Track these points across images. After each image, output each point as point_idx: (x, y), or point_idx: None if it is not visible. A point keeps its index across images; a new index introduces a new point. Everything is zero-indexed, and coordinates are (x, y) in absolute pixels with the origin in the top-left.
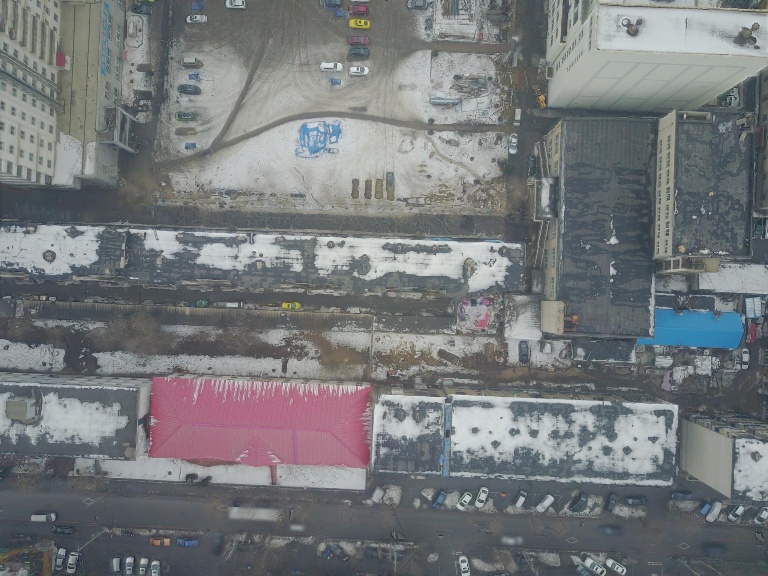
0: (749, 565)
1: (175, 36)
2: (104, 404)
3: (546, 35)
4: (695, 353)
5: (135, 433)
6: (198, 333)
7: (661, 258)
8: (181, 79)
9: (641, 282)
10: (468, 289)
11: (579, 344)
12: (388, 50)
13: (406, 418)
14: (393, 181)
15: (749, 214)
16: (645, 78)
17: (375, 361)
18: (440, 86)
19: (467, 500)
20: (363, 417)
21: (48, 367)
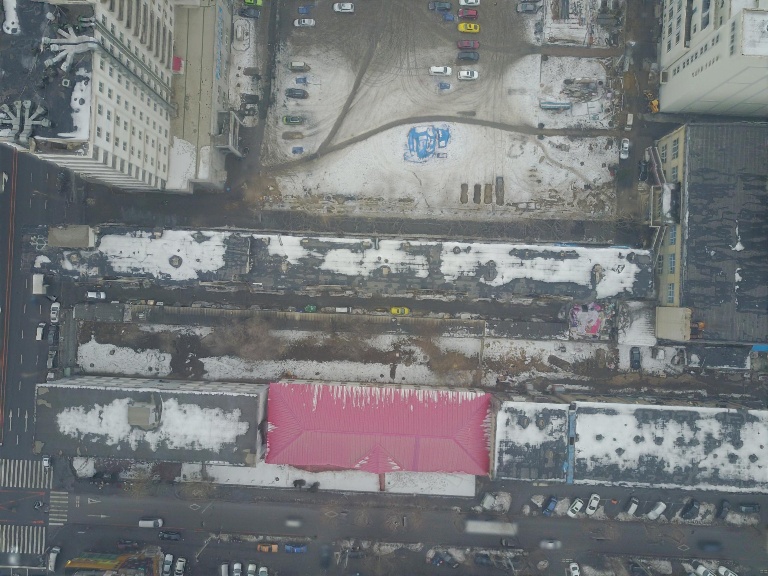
0: None
1: (282, 40)
2: (224, 410)
3: (657, 39)
4: None
5: (255, 439)
6: (306, 338)
7: None
8: (288, 83)
9: (766, 289)
10: (596, 295)
11: (694, 350)
12: (497, 54)
13: (529, 425)
14: (503, 186)
15: None
16: None
17: (485, 367)
18: (550, 90)
19: (579, 507)
20: (483, 424)
21: (154, 372)
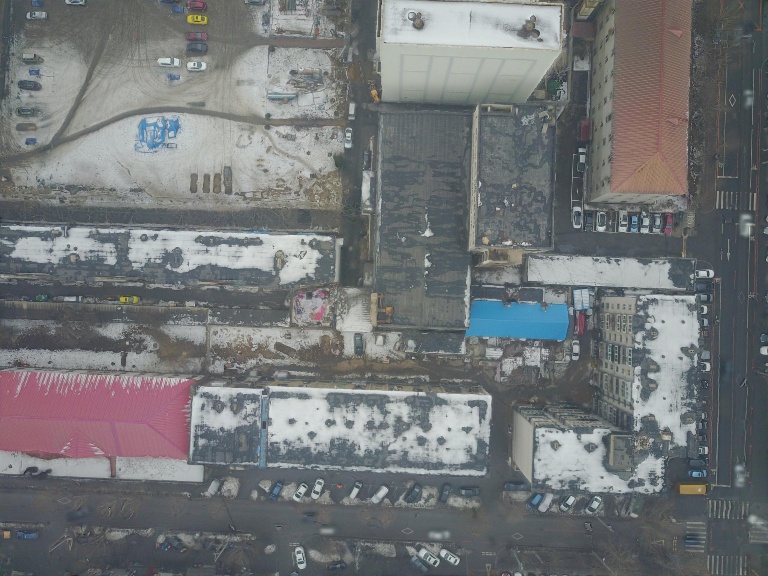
0: (581, 555)
1: (16, 32)
2: None
3: None
4: (527, 345)
5: None
6: (38, 327)
7: (474, 250)
8: (22, 75)
9: (456, 274)
10: (279, 281)
11: (410, 336)
12: (226, 45)
13: (224, 410)
14: (230, 175)
15: (551, 206)
16: (450, 71)
17: (213, 354)
18: (277, 81)
19: (302, 491)
20: (185, 409)
21: None
